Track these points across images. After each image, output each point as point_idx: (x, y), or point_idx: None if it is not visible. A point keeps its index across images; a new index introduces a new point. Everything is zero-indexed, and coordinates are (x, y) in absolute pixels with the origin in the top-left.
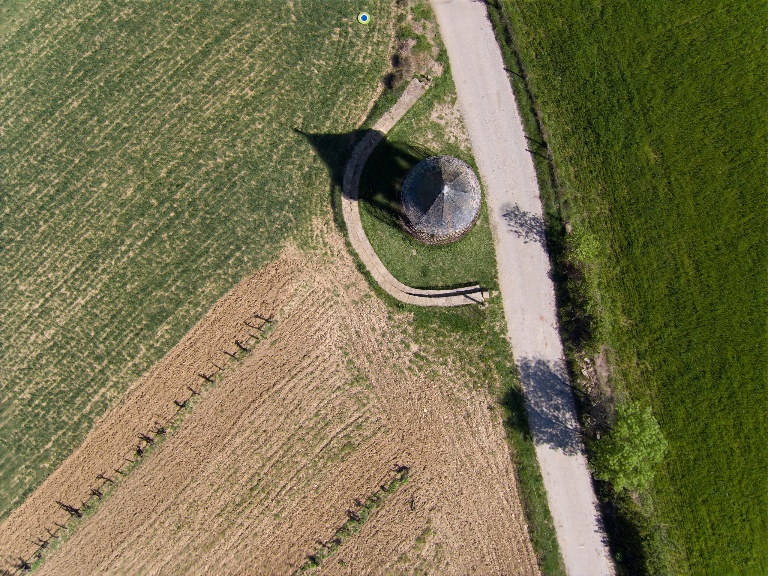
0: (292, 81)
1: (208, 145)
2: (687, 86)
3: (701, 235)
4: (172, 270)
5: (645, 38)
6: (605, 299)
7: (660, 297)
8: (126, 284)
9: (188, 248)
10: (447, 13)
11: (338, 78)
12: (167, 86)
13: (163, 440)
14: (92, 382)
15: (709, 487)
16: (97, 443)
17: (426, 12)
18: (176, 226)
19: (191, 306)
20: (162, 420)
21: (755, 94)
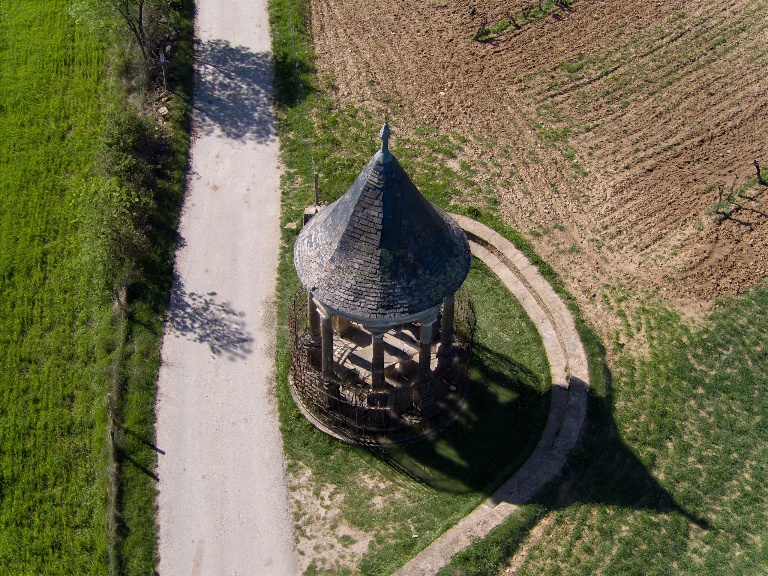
0: None
1: None
2: None
3: None
4: None
5: None
6: None
7: None
8: None
9: None
10: None
11: None
12: None
13: None
14: None
15: (24, 1)
16: None
17: None
18: None
19: None
20: None
21: None
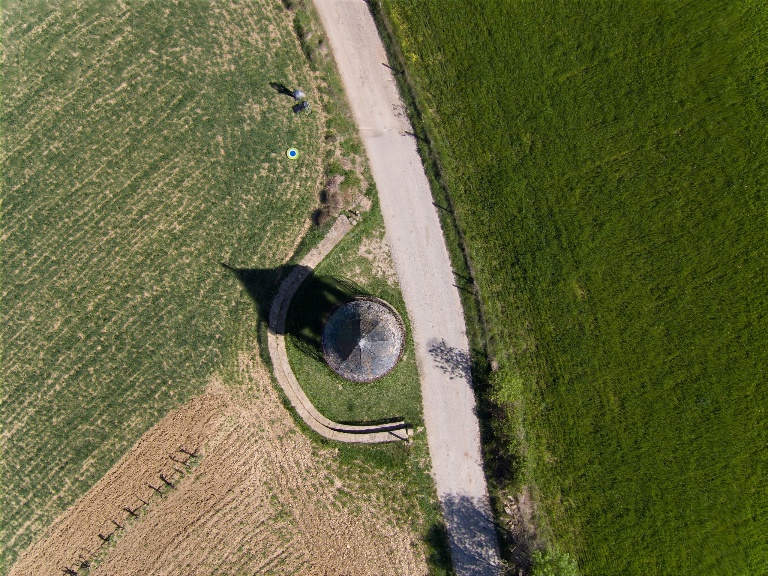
0: (220, 216)
1: (136, 279)
2: (615, 223)
3: (627, 372)
4: (98, 404)
5: (574, 174)
6: (530, 436)
7: (585, 434)
8: (52, 417)
9: (114, 382)
10: (377, 147)
11: (266, 213)
12: (96, 220)
13: (87, 573)
14: (17, 515)
15: None
16: (21, 575)
17: (356, 146)
18: (103, 360)
19: (117, 440)
20: (86, 553)
21: (683, 231)
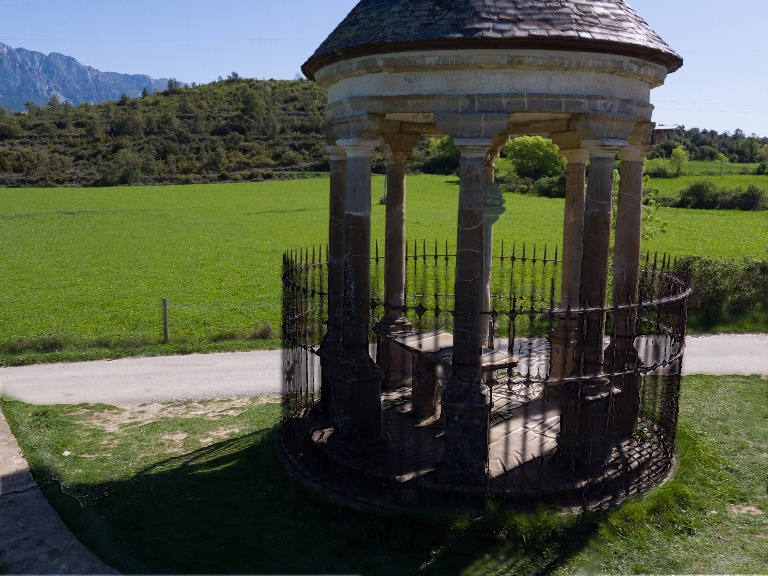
0: None
1: None
2: None
3: None
4: None
5: None
6: None
7: None
8: None
9: None
10: None
11: None
12: None
13: None
14: None
15: None
16: None
17: None
18: None
19: None
20: None
21: None
